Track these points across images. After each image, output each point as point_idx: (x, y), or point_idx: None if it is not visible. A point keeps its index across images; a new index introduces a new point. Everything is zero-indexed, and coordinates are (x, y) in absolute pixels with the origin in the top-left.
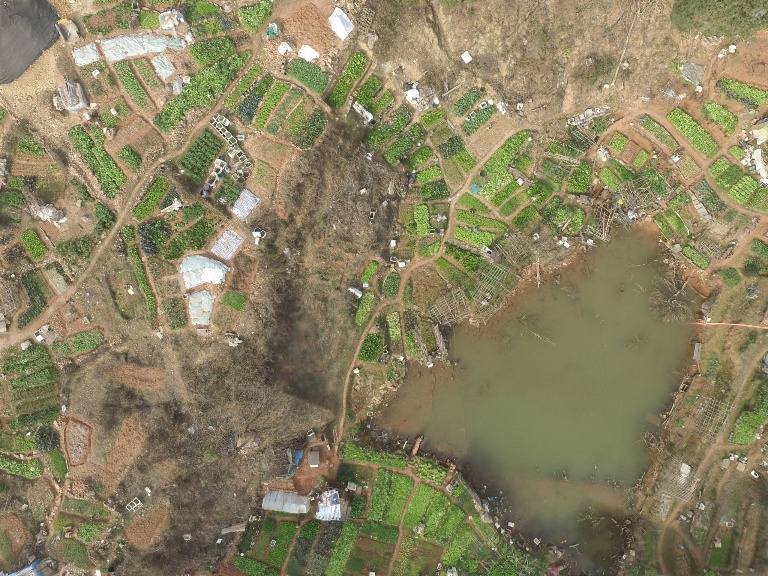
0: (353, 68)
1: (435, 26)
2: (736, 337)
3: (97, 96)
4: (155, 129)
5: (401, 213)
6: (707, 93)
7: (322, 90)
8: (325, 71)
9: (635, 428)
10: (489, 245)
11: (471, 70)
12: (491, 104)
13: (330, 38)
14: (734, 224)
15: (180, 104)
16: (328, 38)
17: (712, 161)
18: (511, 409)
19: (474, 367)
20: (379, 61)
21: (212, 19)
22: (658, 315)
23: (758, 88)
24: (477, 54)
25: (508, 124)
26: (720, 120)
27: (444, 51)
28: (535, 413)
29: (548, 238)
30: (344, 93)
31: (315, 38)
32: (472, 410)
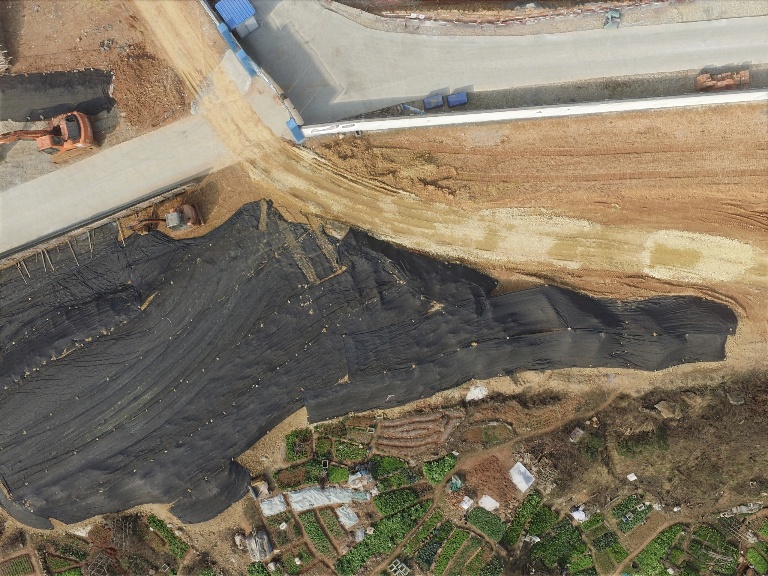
0: (528, 509)
1: (606, 458)
2: None
3: (282, 545)
4: (335, 573)
5: None
6: None
7: (500, 538)
8: (504, 521)
9: None
10: None
11: (634, 484)
12: (648, 504)
13: (511, 490)
14: None
15: (362, 553)
16: (509, 489)
17: None
18: None
19: None
20: (552, 497)
21: (397, 472)
22: None
23: None
24: (642, 475)
25: (662, 519)
26: None
27: (611, 474)
28: None
29: None
30: (518, 531)
31: (496, 490)
32: None
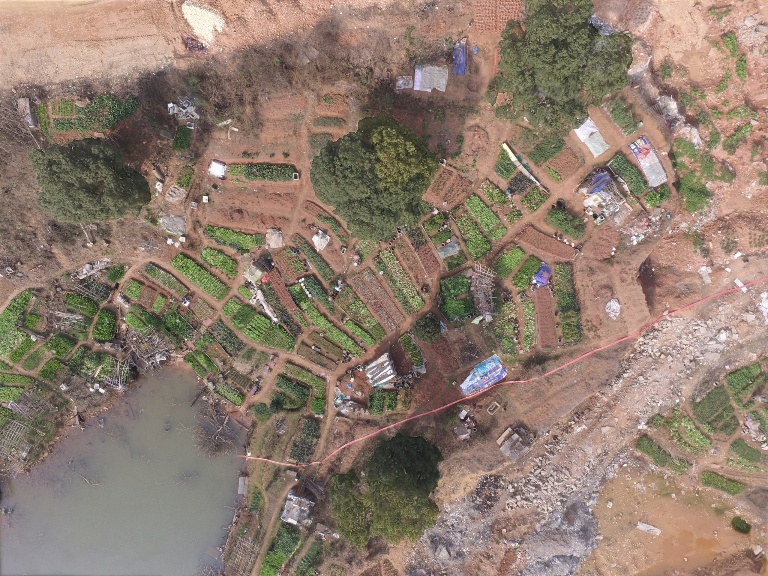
0: None
1: None
2: (266, 473)
3: None
4: None
5: None
6: (199, 240)
7: None
8: None
9: (197, 561)
10: None
11: None
12: None
13: None
14: (254, 362)
15: None
16: None
17: (225, 302)
18: (71, 551)
19: (33, 512)
20: None
21: None
22: (202, 452)
23: (245, 232)
24: None
25: (10, 285)
26: (218, 264)
27: None
28: (95, 554)
29: (81, 386)
30: None
31: None
32: (32, 555)
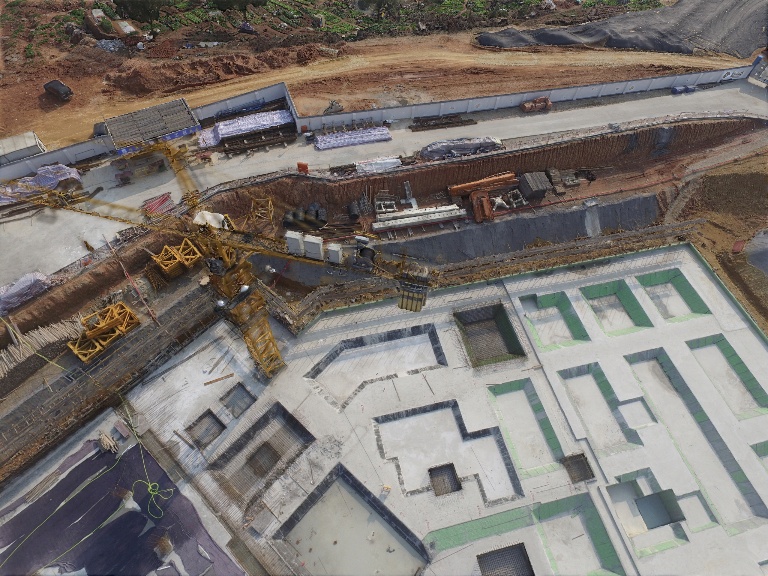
0: (537, 2)
1: None
2: None
3: None
4: None
5: (490, 4)
6: None
7: None
8: None
9: None
10: (444, 1)
11: None
12: None
13: None
14: (326, 7)
15: None
16: (553, 2)
17: None
18: None
19: None
20: None
21: None
22: None
23: None
24: None
25: None
26: None
27: None
28: None
29: (415, 7)
30: None
31: None
32: None
